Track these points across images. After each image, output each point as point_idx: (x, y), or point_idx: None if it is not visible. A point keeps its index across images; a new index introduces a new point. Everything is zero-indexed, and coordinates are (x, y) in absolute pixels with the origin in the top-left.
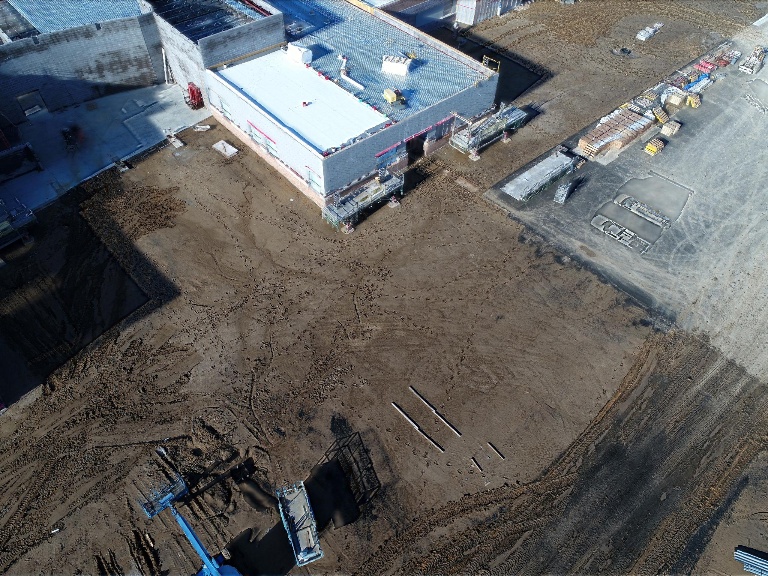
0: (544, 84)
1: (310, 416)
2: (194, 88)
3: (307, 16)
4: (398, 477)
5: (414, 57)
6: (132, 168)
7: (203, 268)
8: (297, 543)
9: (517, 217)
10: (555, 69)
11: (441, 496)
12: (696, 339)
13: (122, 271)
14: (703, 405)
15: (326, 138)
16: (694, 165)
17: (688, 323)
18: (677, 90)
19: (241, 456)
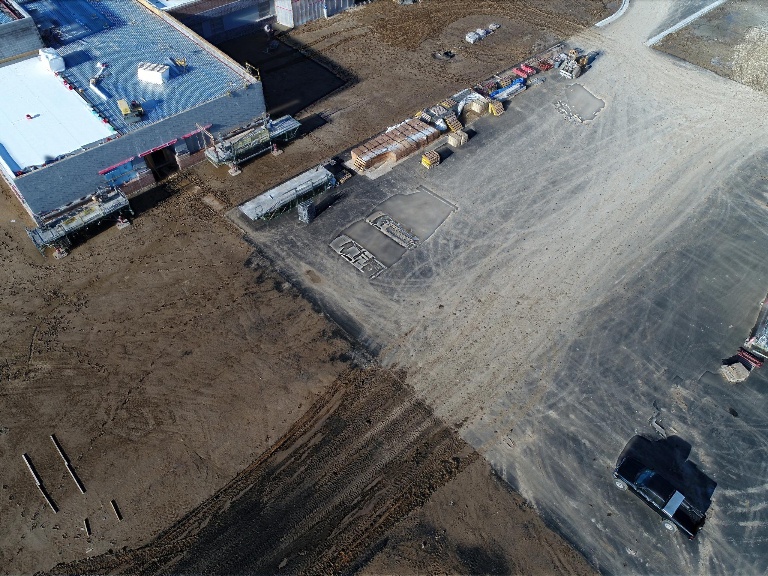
0: (345, 91)
1: None
2: None
3: (88, 20)
4: None
5: (182, 64)
6: None
7: None
8: None
9: (251, 238)
10: (364, 74)
11: (31, 566)
12: (392, 376)
13: None
14: (371, 453)
15: (33, 155)
16: (470, 178)
17: (390, 358)
18: (479, 97)
19: None
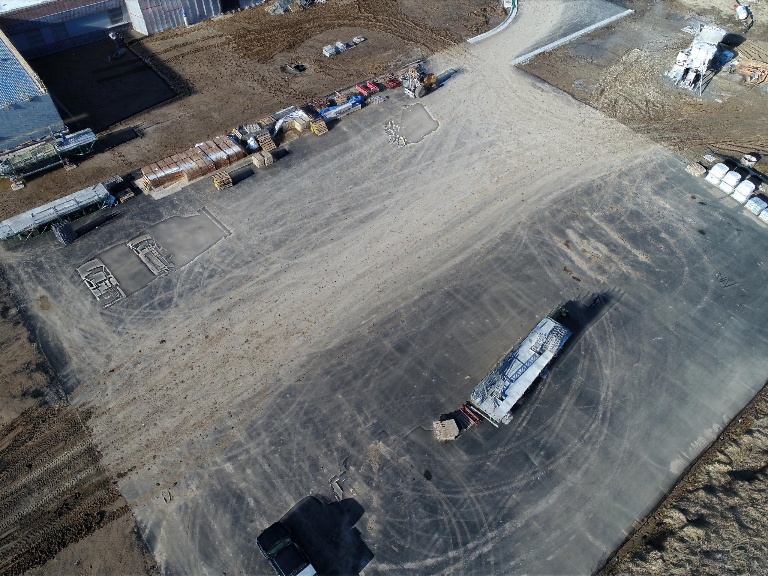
0: (172, 103)
1: None
2: None
3: None
4: None
5: None
6: None
7: None
8: None
9: None
10: (200, 87)
11: None
12: (75, 416)
13: None
14: (17, 501)
15: None
16: (259, 202)
17: (83, 396)
18: (301, 115)
19: None
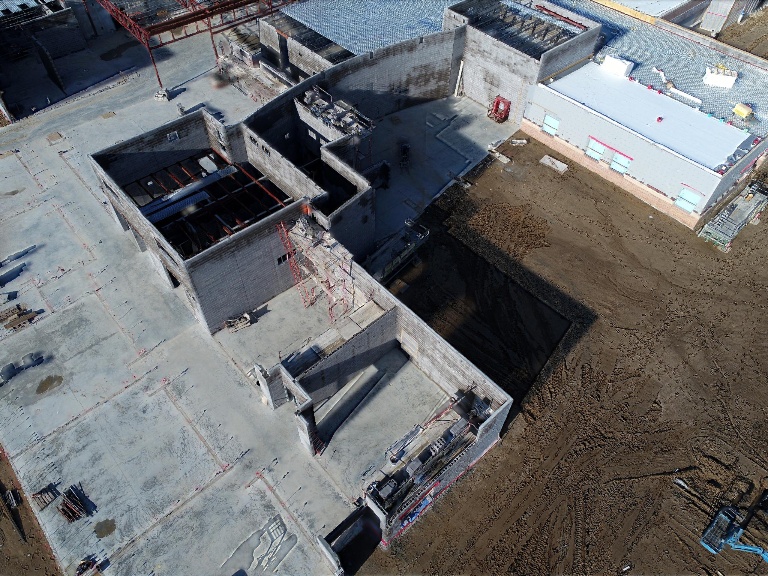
0: None
1: None
2: (505, 101)
3: None
4: None
5: None
6: (473, 185)
7: (604, 289)
8: None
9: None
10: None
11: None
12: None
13: (527, 293)
14: None
15: (705, 155)
16: None
17: None
18: None
19: (757, 488)
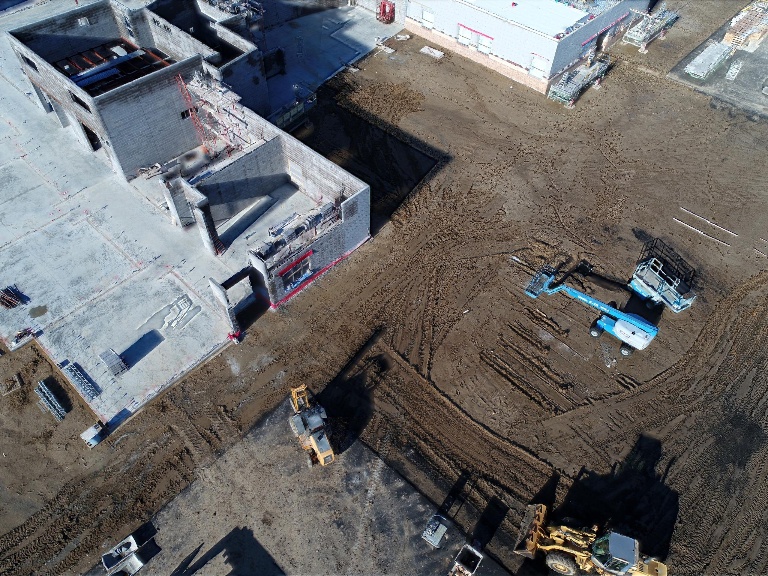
0: None
1: (615, 230)
2: (389, 3)
3: None
4: (705, 263)
5: None
6: (361, 70)
7: (467, 138)
8: (666, 299)
9: (702, 91)
10: None
11: (744, 272)
12: None
13: (402, 143)
14: None
15: (548, 28)
16: None
17: None
18: None
19: (575, 259)
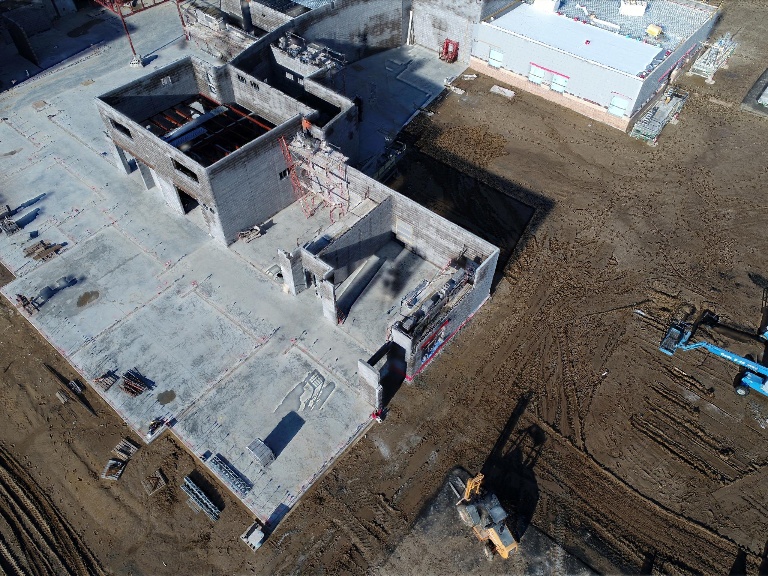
0: (721, 22)
1: (730, 276)
2: (453, 43)
3: None
4: None
5: None
6: (435, 113)
7: (559, 182)
8: None
9: None
10: None
11: None
12: None
13: (495, 191)
14: None
15: (628, 66)
16: None
17: None
18: None
19: (698, 310)
